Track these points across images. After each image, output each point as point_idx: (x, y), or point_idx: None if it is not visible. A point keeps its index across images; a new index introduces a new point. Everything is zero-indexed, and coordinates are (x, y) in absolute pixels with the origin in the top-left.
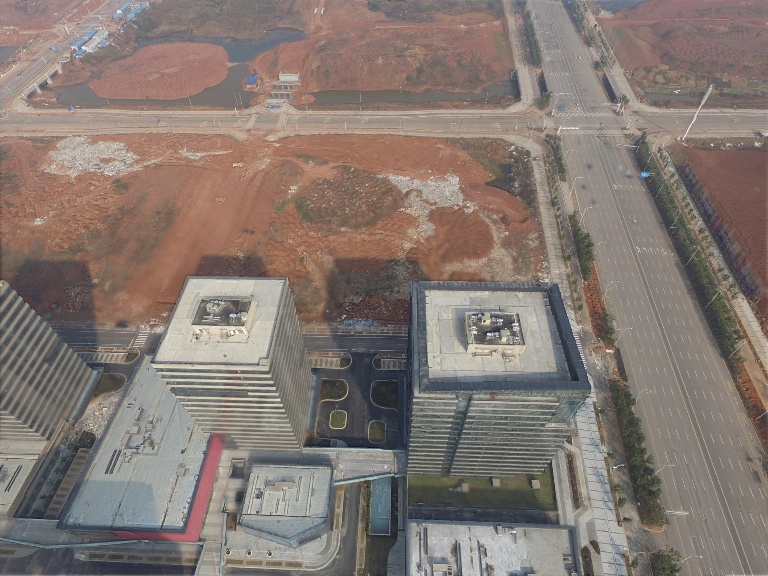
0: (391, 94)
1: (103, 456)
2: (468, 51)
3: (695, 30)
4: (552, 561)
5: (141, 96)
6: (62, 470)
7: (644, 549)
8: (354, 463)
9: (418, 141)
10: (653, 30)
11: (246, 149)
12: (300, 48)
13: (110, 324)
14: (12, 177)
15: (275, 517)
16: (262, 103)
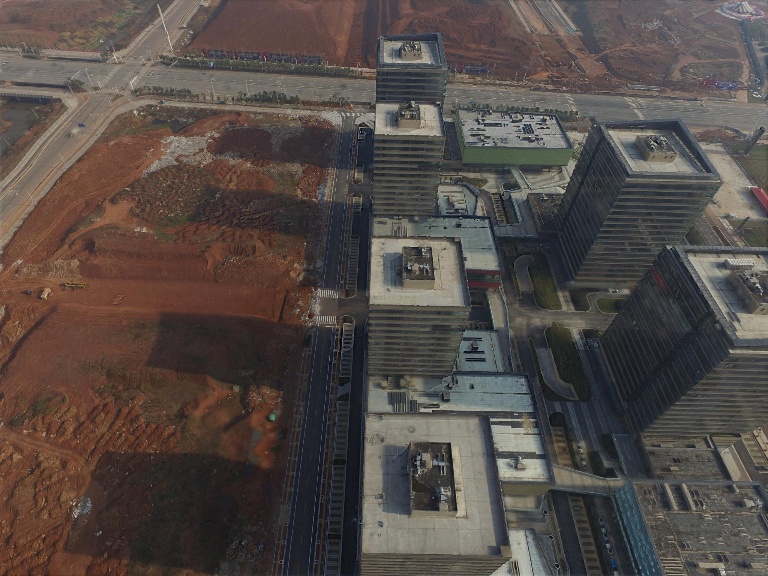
0: None
1: None
2: None
3: (28, 7)
4: (471, 115)
5: None
6: None
7: (450, 115)
8: None
9: (96, 154)
10: None
11: (5, 293)
12: None
13: (305, 352)
14: None
15: (467, 204)
16: None
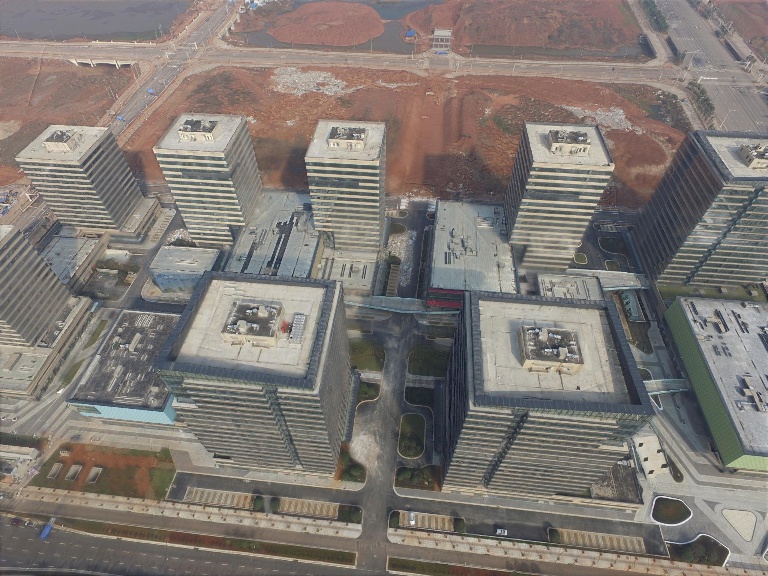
0: (535, 50)
1: (438, 255)
2: (599, 17)
3: None
4: None
5: (318, 42)
6: (386, 275)
7: None
8: (608, 279)
9: (579, 83)
10: (764, 7)
11: (431, 83)
12: (445, 10)
13: None
14: (249, 93)
15: None
16: (430, 50)
